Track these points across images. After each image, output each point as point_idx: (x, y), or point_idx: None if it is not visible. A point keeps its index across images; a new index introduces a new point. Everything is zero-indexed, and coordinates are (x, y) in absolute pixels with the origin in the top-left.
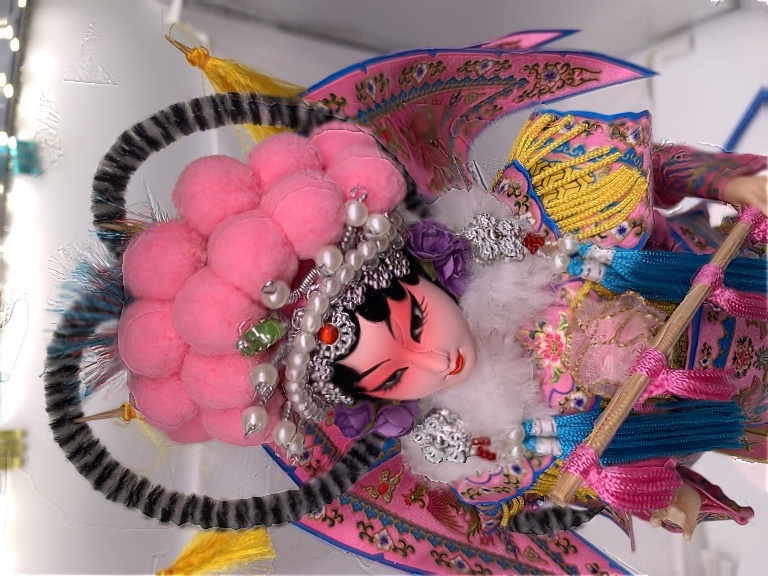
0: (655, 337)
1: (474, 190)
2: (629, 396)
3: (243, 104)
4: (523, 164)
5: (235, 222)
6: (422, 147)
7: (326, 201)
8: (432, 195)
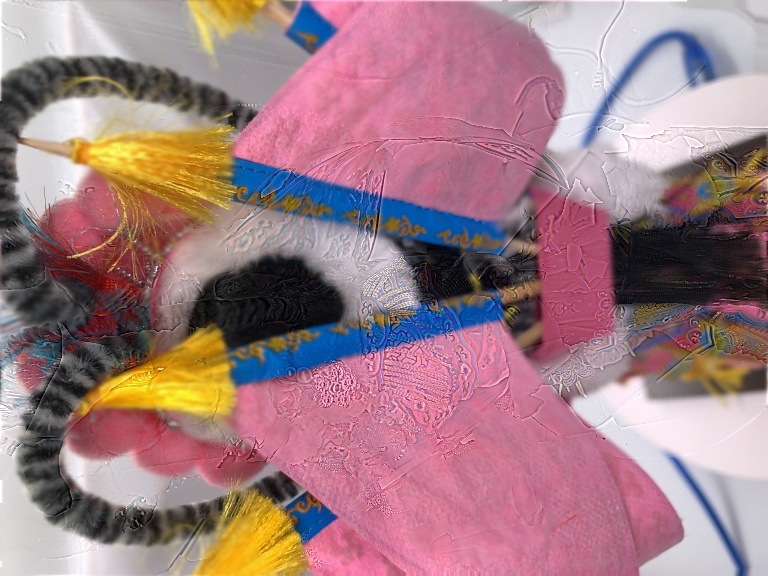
0: (394, 474)
1: (347, 312)
2: (354, 519)
3: (167, 319)
4: (390, 322)
5: (138, 467)
6: (332, 218)
7: (210, 468)
8: (320, 264)
